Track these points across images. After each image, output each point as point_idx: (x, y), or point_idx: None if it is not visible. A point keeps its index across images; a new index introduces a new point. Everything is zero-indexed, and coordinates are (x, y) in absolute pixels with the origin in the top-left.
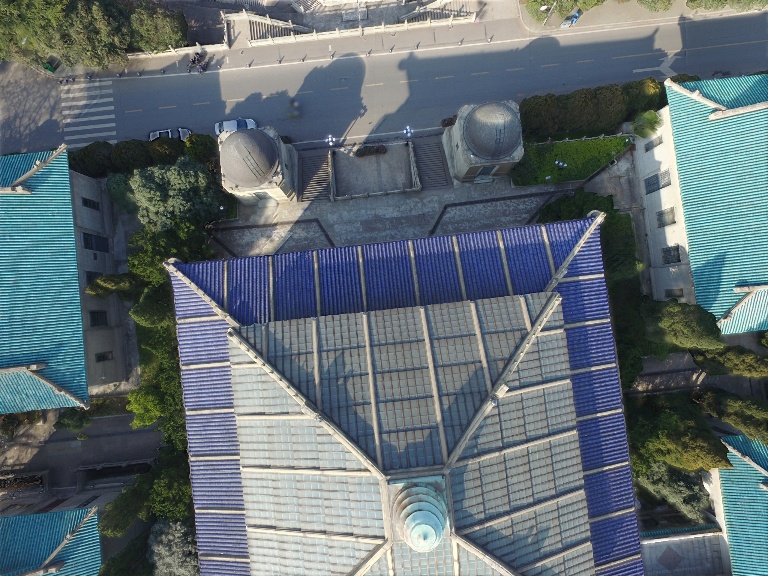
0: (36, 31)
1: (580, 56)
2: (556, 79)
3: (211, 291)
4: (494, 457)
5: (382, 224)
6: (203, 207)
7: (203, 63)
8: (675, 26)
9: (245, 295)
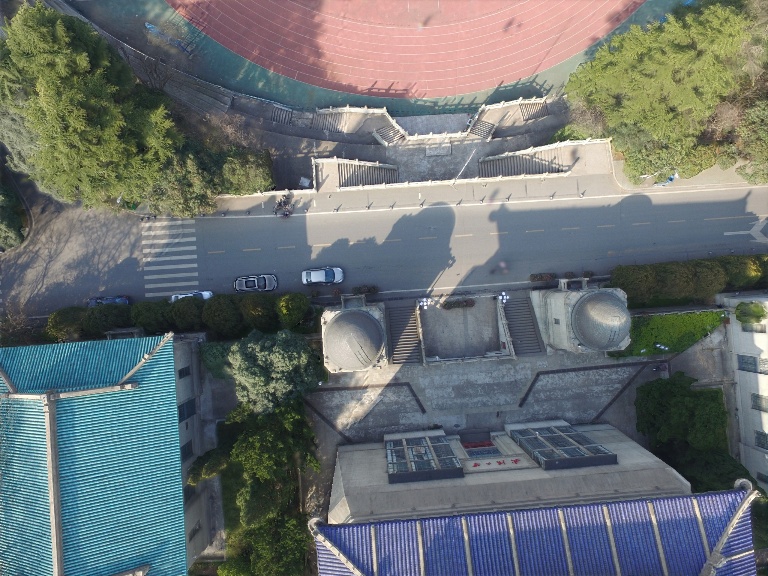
0: (132, 190)
1: (672, 216)
2: (647, 238)
3: (359, 562)
4: None
5: (474, 390)
6: (304, 387)
7: (290, 206)
8: (767, 190)
9: (394, 568)
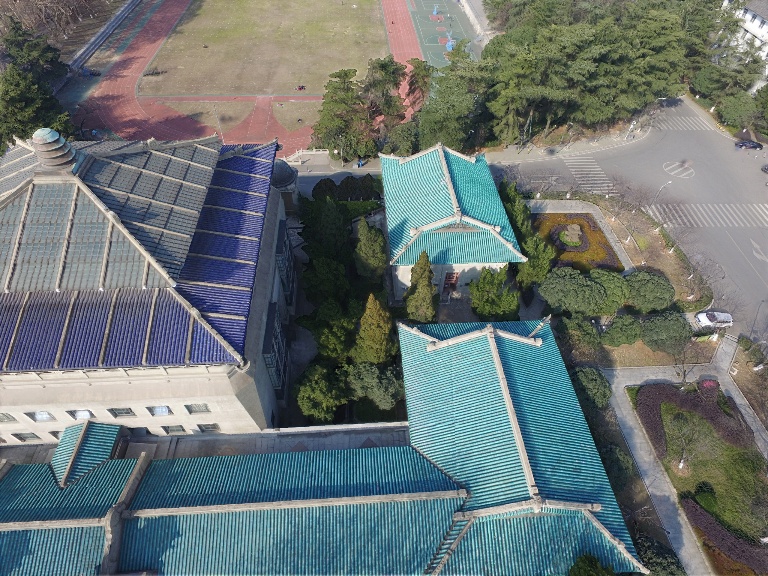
0: None
1: None
2: None
3: None
4: (133, 169)
5: None
6: None
7: None
8: None
9: None
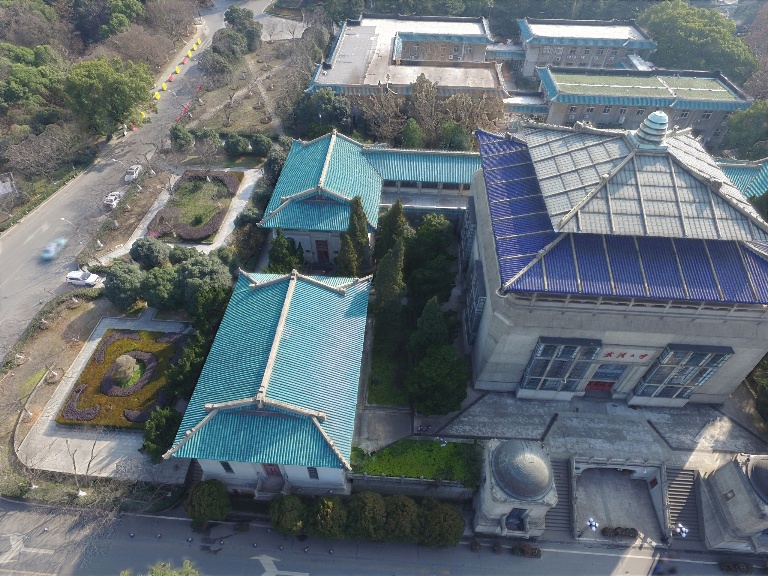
0: None
1: None
2: None
3: None
4: None
5: (605, 434)
6: None
7: None
8: None
9: None
